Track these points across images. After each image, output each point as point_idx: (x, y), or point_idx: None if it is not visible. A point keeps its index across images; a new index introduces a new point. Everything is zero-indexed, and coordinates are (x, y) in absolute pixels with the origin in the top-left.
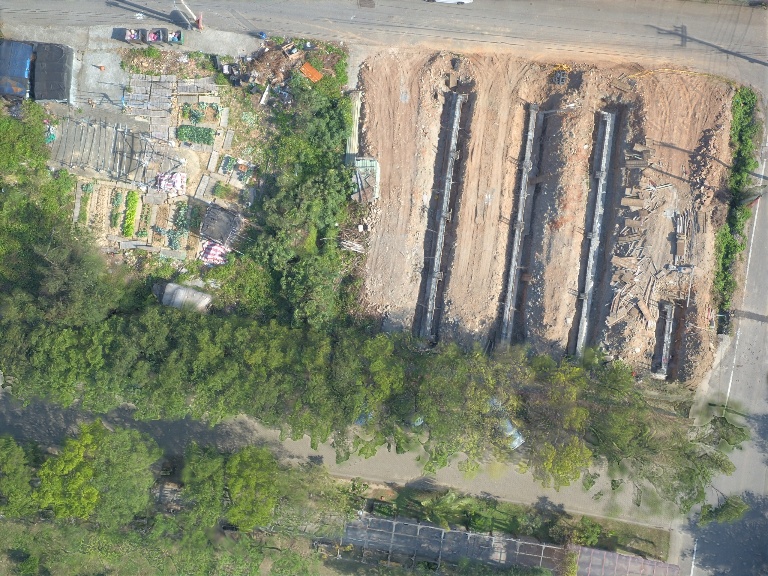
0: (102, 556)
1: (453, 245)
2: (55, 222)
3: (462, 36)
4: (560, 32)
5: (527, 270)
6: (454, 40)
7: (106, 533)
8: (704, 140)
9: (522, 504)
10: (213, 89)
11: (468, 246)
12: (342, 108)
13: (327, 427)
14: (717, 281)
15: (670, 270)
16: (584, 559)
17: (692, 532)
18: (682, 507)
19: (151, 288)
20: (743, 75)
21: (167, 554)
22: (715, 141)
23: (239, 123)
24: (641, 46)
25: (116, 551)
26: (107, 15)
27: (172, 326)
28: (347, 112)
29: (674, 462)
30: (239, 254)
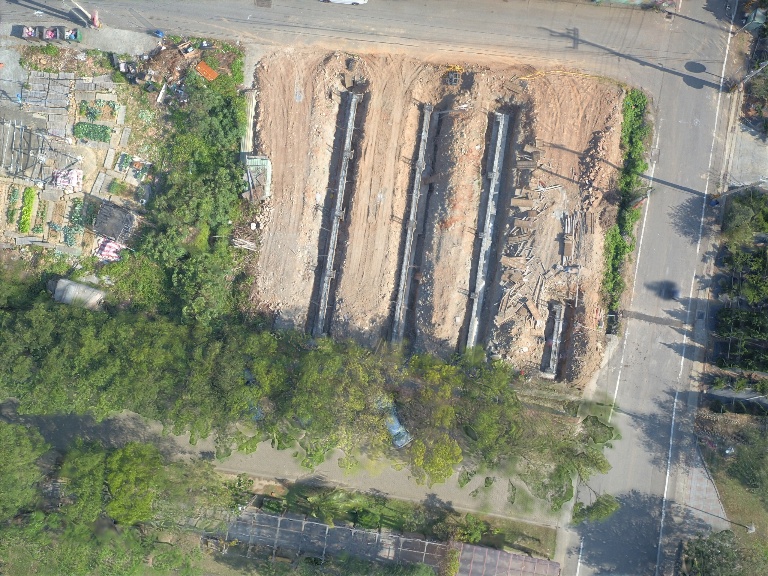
0: None
1: (345, 244)
2: None
3: (357, 36)
4: (454, 33)
5: (419, 269)
6: (349, 40)
7: None
8: (594, 142)
9: (411, 501)
10: (110, 87)
11: (360, 245)
12: (235, 107)
13: (206, 423)
14: (606, 282)
15: (558, 270)
16: (466, 556)
17: (579, 530)
18: (553, 505)
19: (46, 284)
20: (634, 78)
21: (49, 547)
22: (604, 143)
23: (136, 121)
24: (533, 48)
25: None
26: (7, 12)
27: (57, 322)
28: (240, 111)
29: (560, 460)
30: (133, 251)
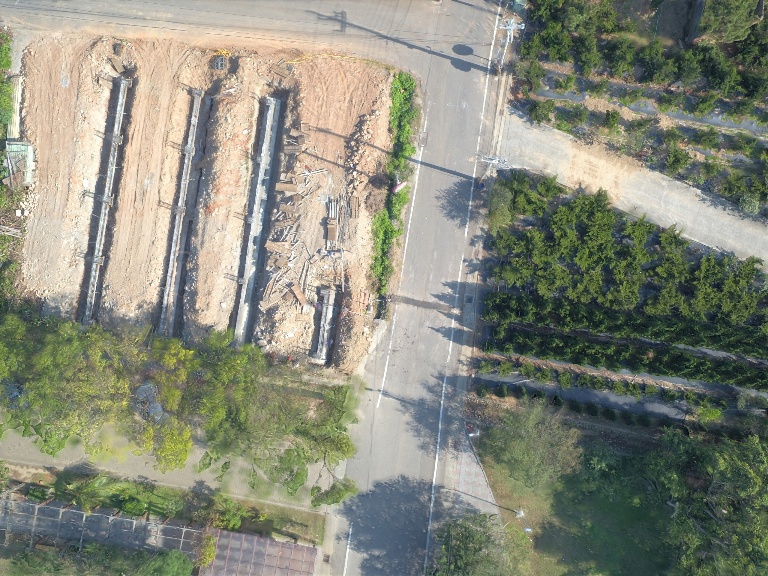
0: None
1: (112, 230)
2: None
3: (125, 21)
4: (221, 17)
5: None
6: (117, 25)
7: None
8: (359, 125)
9: (179, 488)
10: None
11: (127, 231)
12: None
13: None
14: (374, 266)
15: (322, 255)
16: (223, 542)
17: (347, 516)
18: (287, 489)
19: None
20: (402, 61)
21: None
22: (369, 126)
23: None
24: (301, 32)
25: None
26: None
27: None
28: (3, 97)
29: None
30: None
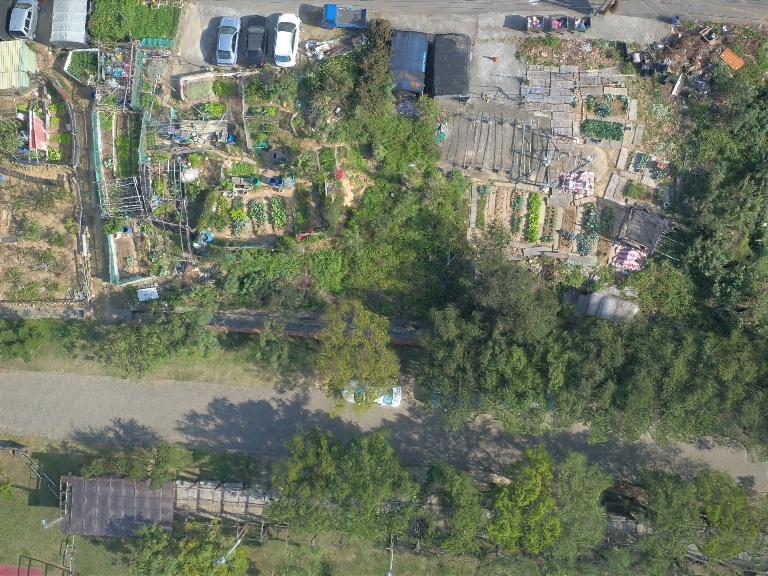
0: None
1: None
2: (451, 228)
3: None
4: None
5: None
6: None
7: (566, 567)
8: None
9: None
10: (619, 80)
11: None
12: None
13: None
14: None
15: None
16: None
17: None
18: None
19: (561, 298)
20: None
21: None
22: None
23: (649, 116)
24: None
25: None
26: (498, 1)
27: (625, 340)
28: None
29: None
30: (658, 259)
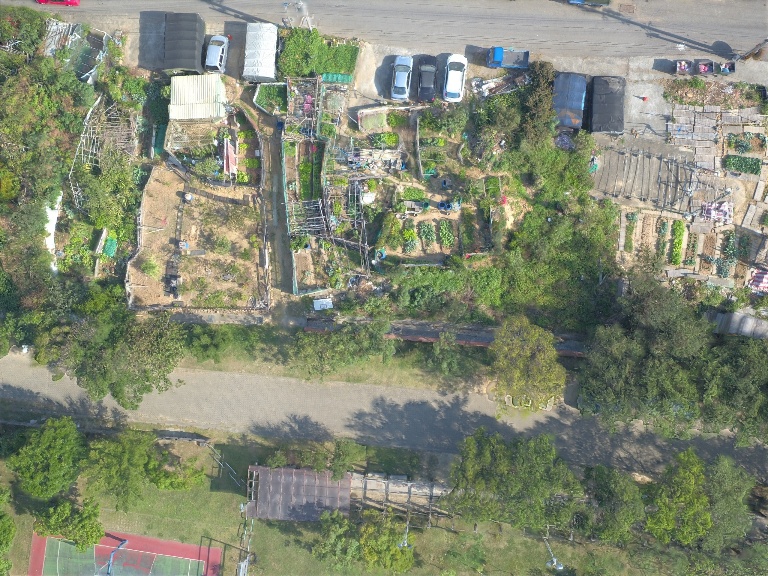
0: (648, 575)
1: None
2: (602, 251)
3: None
4: None
5: None
6: None
7: (715, 558)
8: None
9: None
10: (757, 119)
11: None
12: None
13: None
14: None
15: None
16: None
17: None
18: None
19: (701, 316)
20: None
21: None
22: None
23: None
24: None
25: (721, 575)
26: (648, 46)
27: None
28: None
29: None
30: None
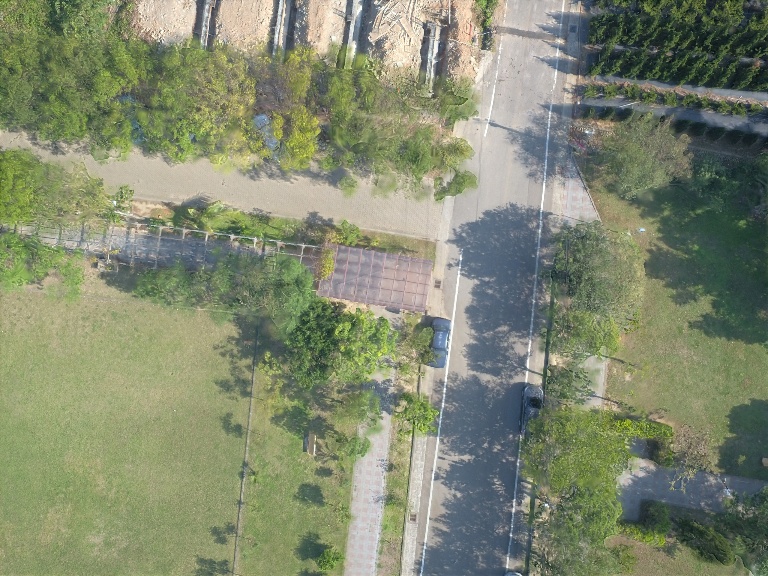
0: None
1: None
2: None
3: None
4: None
5: None
6: None
7: None
8: None
9: (293, 219)
10: None
11: None
12: None
13: (80, 119)
14: None
15: None
16: (341, 257)
17: (458, 242)
18: (411, 177)
19: None
20: None
21: None
22: None
23: None
24: None
25: None
26: None
27: None
28: None
29: (436, 172)
30: None
